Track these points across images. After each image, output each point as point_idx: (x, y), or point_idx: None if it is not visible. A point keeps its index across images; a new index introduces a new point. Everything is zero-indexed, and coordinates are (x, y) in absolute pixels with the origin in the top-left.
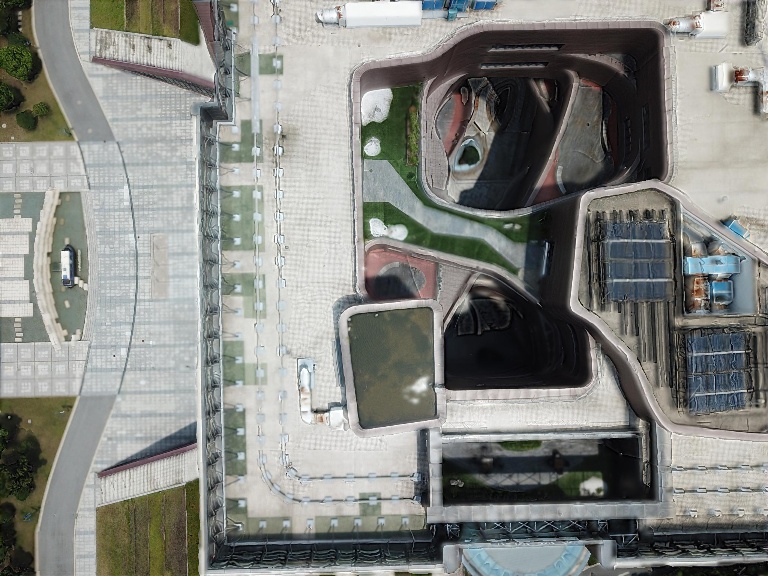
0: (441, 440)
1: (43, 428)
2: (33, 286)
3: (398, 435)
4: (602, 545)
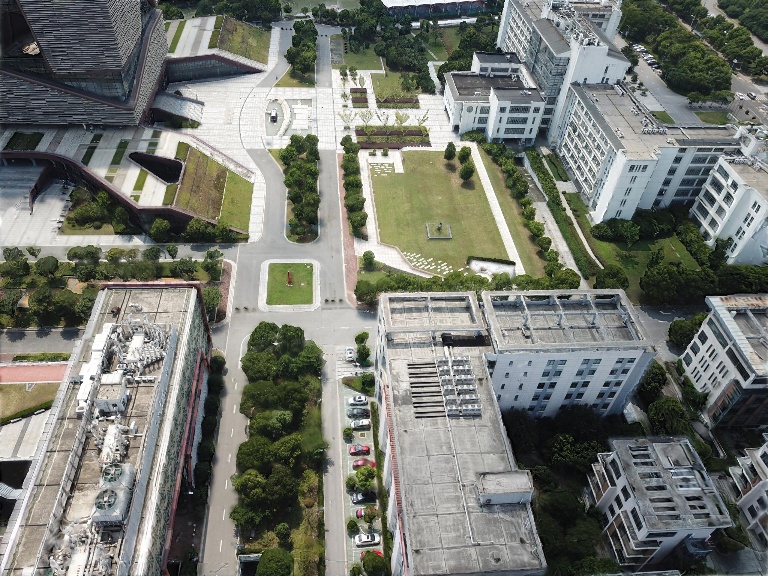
0: None
1: (288, 80)
2: (292, 112)
3: None
4: None
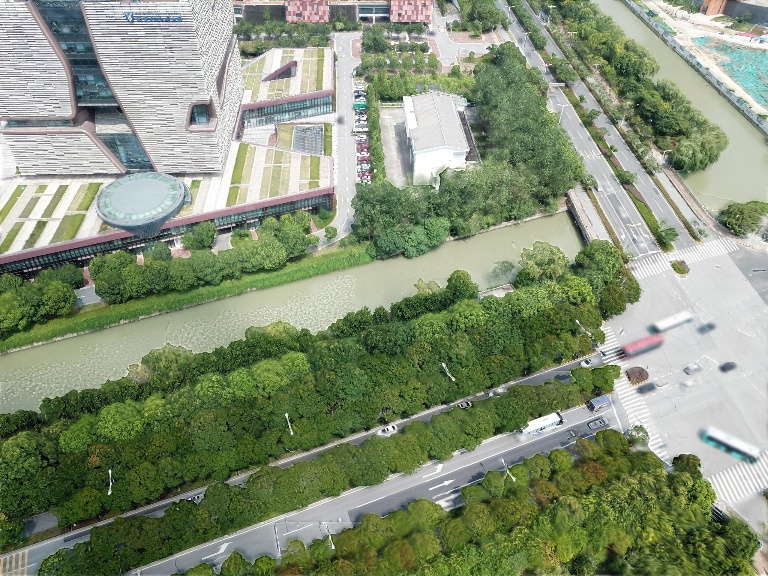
0: None
1: None
2: None
3: None
4: None
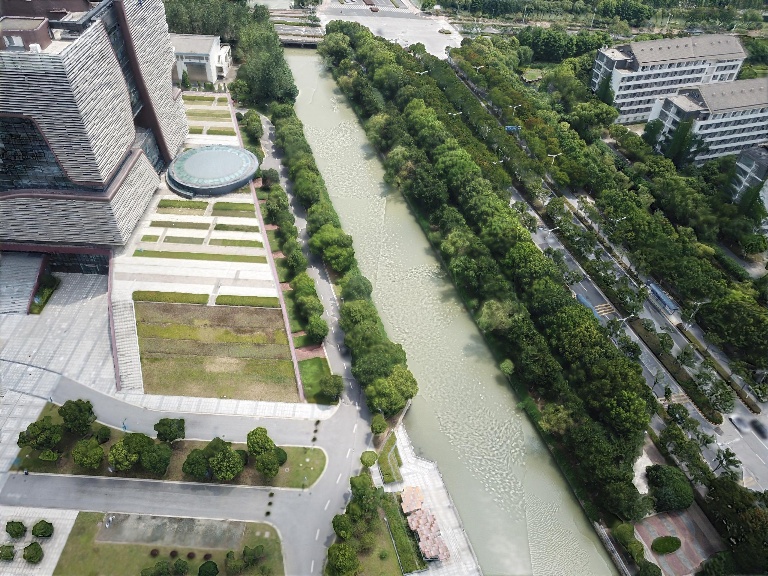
0: (54, 20)
1: None
2: None
3: (55, 44)
4: (113, 0)
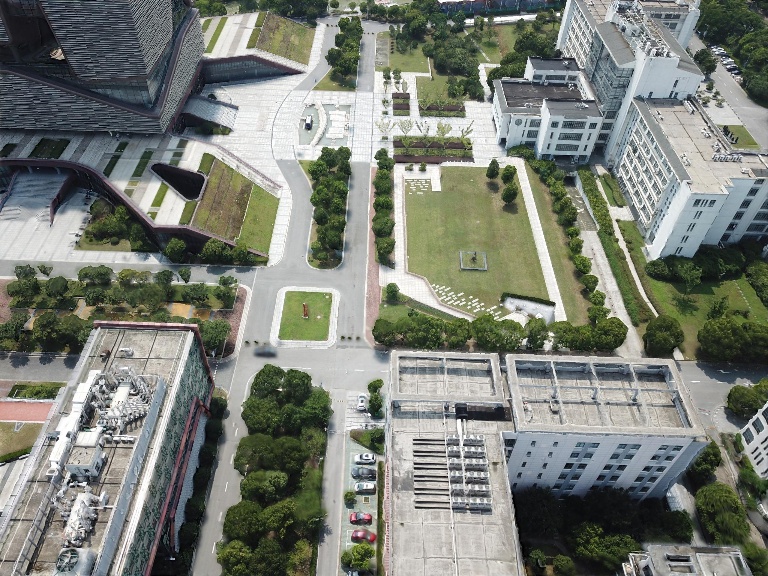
0: None
1: (328, 83)
2: (328, 119)
3: None
4: None
